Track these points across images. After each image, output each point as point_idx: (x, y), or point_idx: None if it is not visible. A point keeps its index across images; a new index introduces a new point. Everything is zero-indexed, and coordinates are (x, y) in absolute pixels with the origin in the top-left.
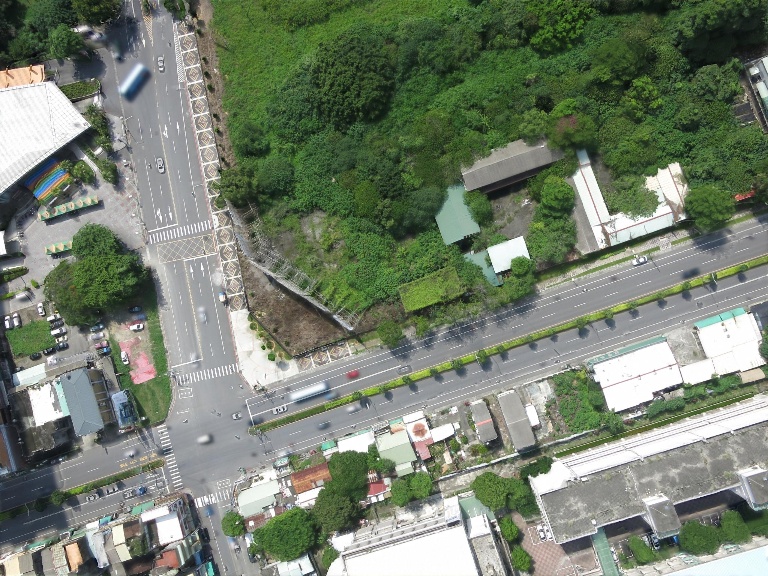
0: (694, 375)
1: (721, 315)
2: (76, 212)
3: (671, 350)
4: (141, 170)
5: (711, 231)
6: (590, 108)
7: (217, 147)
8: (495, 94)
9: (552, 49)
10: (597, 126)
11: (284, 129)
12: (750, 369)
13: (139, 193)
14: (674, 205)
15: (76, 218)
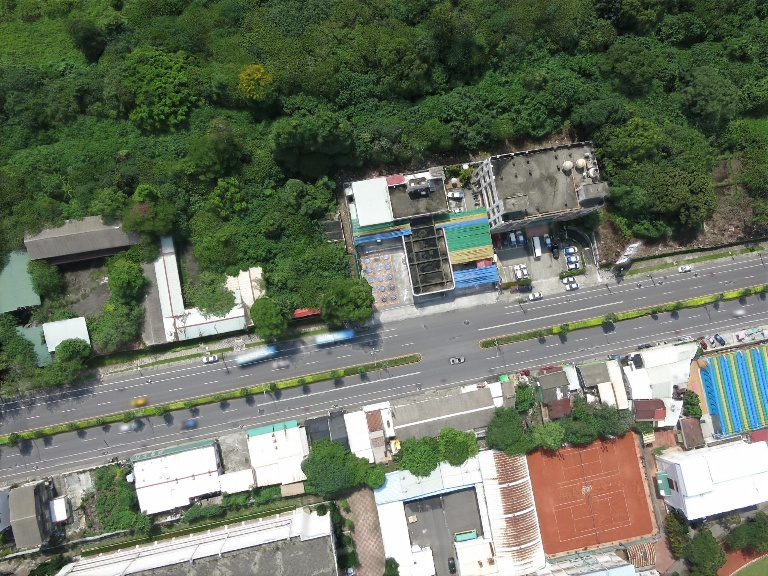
0: (232, 484)
1: (275, 425)
2: None
3: (217, 456)
4: None
5: (286, 339)
6: (176, 197)
7: None
8: (80, 163)
9: (153, 129)
10: (187, 216)
11: None
12: (292, 483)
13: None
14: (248, 309)
15: None
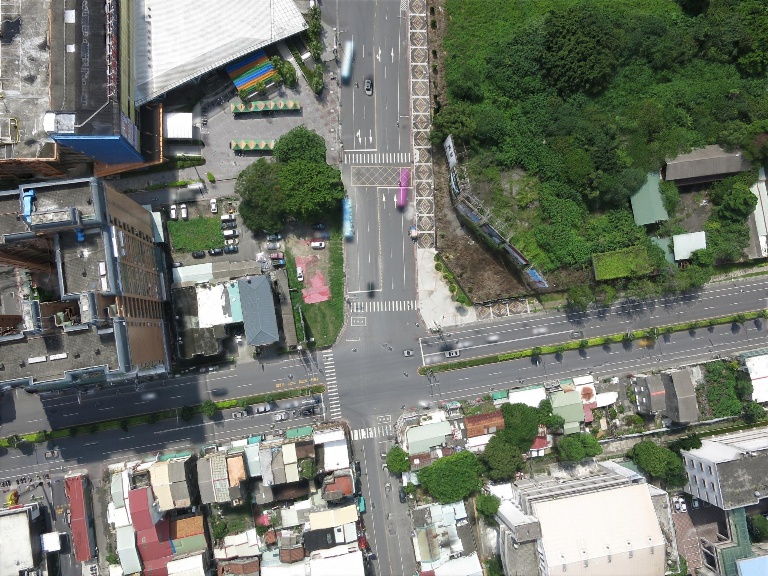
0: None
1: None
2: (271, 113)
3: None
4: (347, 87)
5: None
6: None
7: (430, 83)
8: (703, 99)
9: (753, 72)
10: None
11: (506, 82)
12: None
13: (340, 109)
14: None
15: (269, 119)
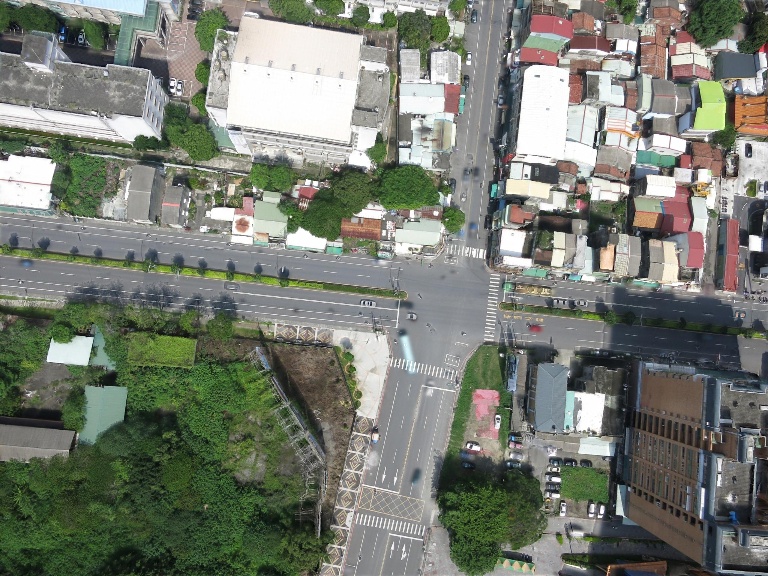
0: None
1: None
2: None
3: None
4: None
5: None
6: None
7: None
8: None
9: None
10: None
11: None
12: None
13: None
14: None
15: None
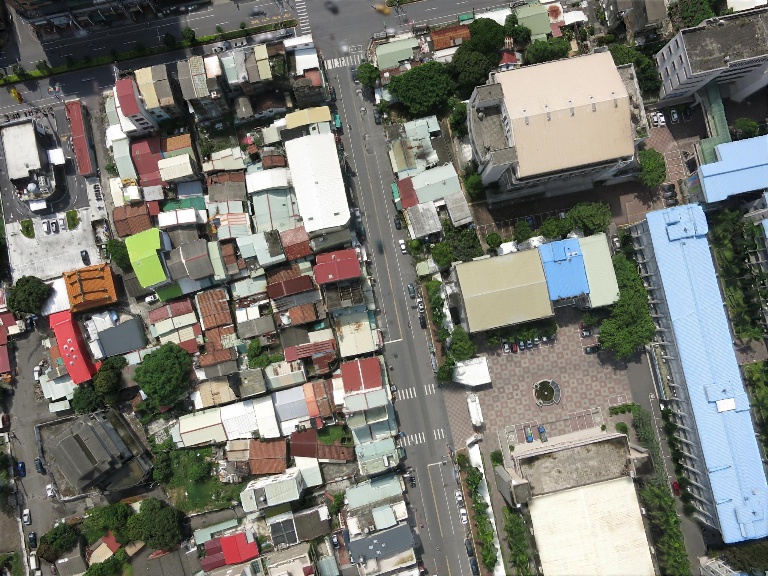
0: None
1: None
2: None
3: None
4: None
5: None
6: None
7: None
8: None
9: None
10: None
11: None
12: None
13: None
14: None
15: None
